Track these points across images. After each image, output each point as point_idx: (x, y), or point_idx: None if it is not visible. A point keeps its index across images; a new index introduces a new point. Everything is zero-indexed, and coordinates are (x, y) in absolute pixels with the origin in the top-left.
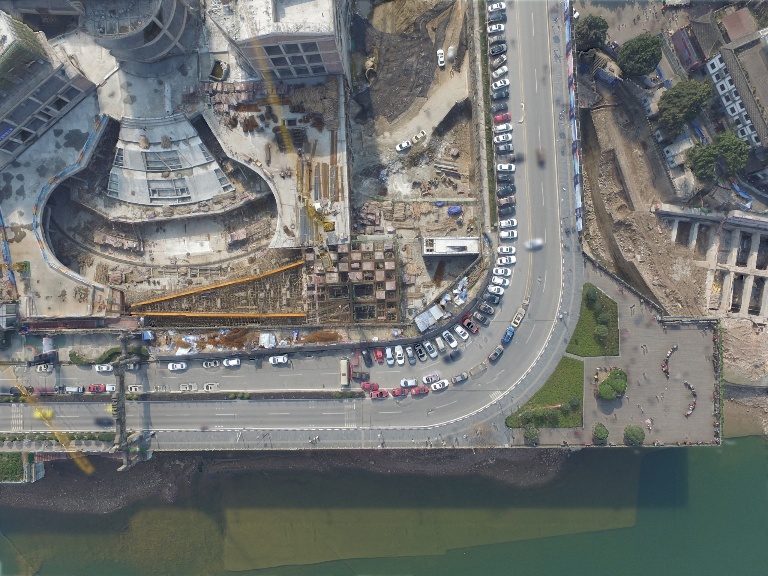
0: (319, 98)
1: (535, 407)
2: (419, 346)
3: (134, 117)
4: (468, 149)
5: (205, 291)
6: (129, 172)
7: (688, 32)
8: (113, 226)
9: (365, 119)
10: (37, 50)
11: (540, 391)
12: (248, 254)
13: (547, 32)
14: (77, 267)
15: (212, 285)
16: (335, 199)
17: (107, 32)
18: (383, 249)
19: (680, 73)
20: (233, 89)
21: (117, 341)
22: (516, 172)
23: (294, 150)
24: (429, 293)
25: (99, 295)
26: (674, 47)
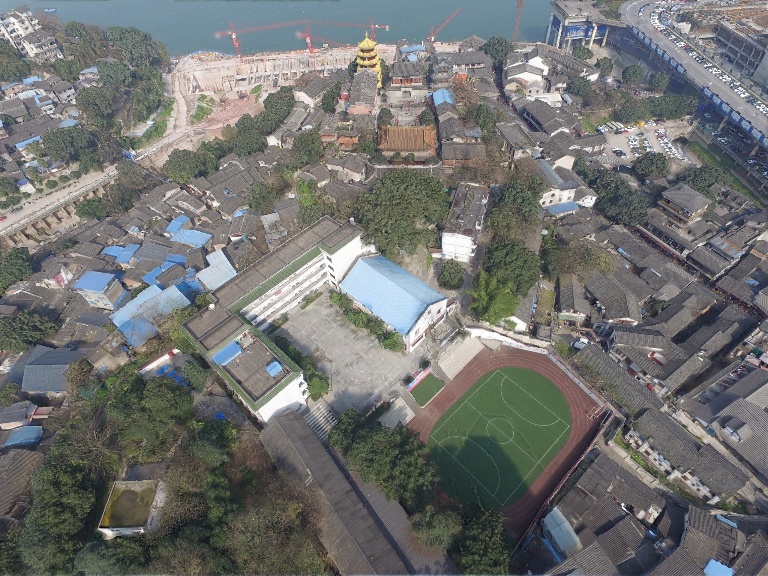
0: None
1: (621, 1)
2: None
3: None
4: None
5: (765, 14)
6: None
7: None
8: None
9: None
10: None
11: (622, 4)
12: None
13: None
14: None
15: (764, 15)
16: None
17: None
18: None
19: None
20: None
21: None
22: None
23: None
24: None
25: None
26: None
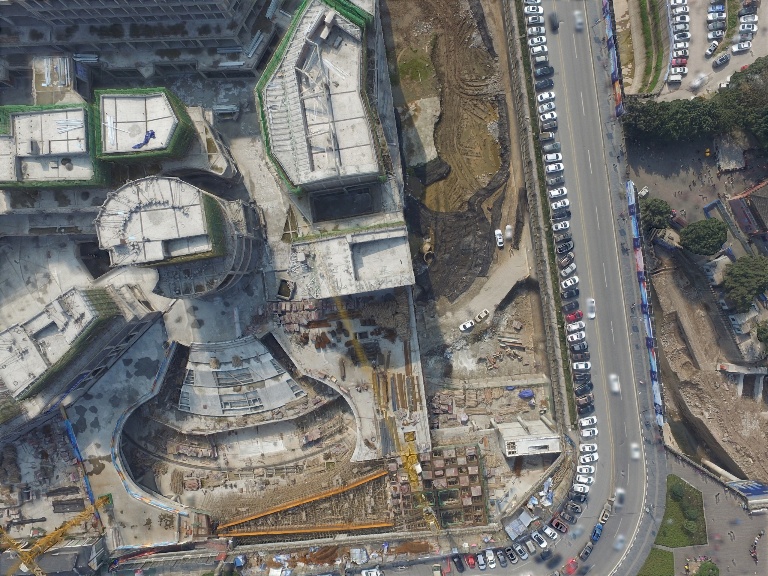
0: (391, 314)
1: None
2: (510, 551)
3: (204, 342)
4: (530, 320)
5: None
6: (200, 389)
7: (747, 202)
8: (186, 437)
9: (426, 301)
10: (112, 313)
11: None
12: (323, 450)
13: (612, 225)
14: (152, 476)
15: (295, 498)
16: (413, 409)
17: (183, 293)
18: (465, 454)
19: (740, 238)
20: (302, 308)
21: (207, 566)
22: (592, 368)
23: (368, 363)
24: (509, 483)
25: (185, 521)
26: (732, 211)
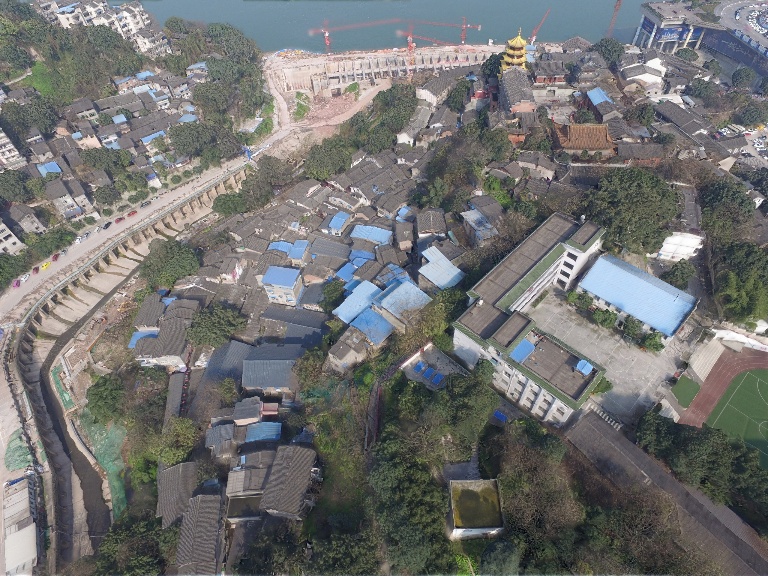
0: None
1: None
2: None
3: None
4: None
5: None
6: None
7: None
8: None
9: None
10: None
11: (715, 7)
12: None
13: None
14: None
15: None
16: None
17: None
18: None
19: None
20: None
21: None
22: None
23: None
24: None
25: None
26: None
